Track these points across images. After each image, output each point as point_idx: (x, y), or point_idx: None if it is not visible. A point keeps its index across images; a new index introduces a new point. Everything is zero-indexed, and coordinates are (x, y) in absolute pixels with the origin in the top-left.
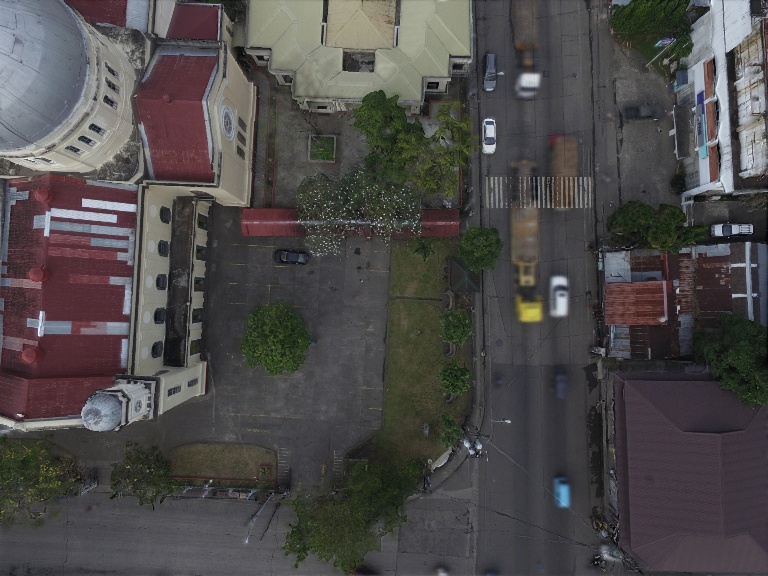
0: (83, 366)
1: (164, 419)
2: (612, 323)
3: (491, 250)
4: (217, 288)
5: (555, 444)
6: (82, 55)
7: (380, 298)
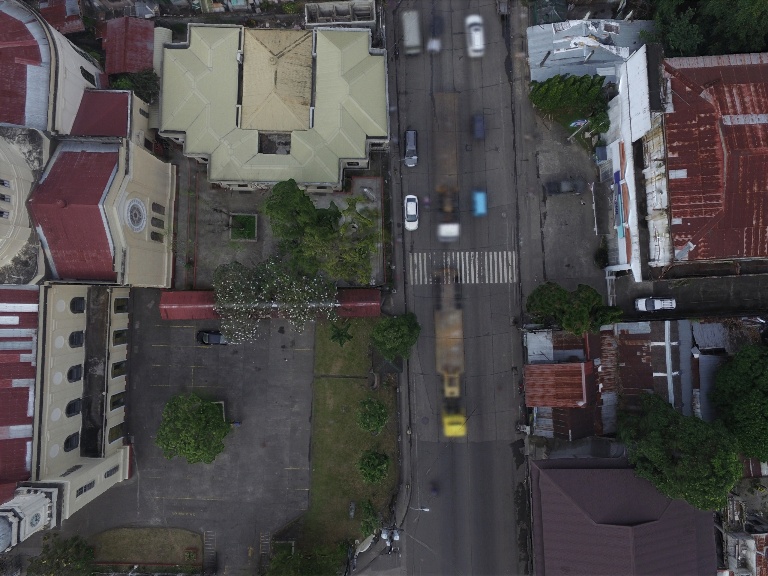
0: None
1: (88, 504)
2: (533, 405)
3: (403, 341)
4: (139, 370)
5: (483, 522)
6: None
7: (305, 377)
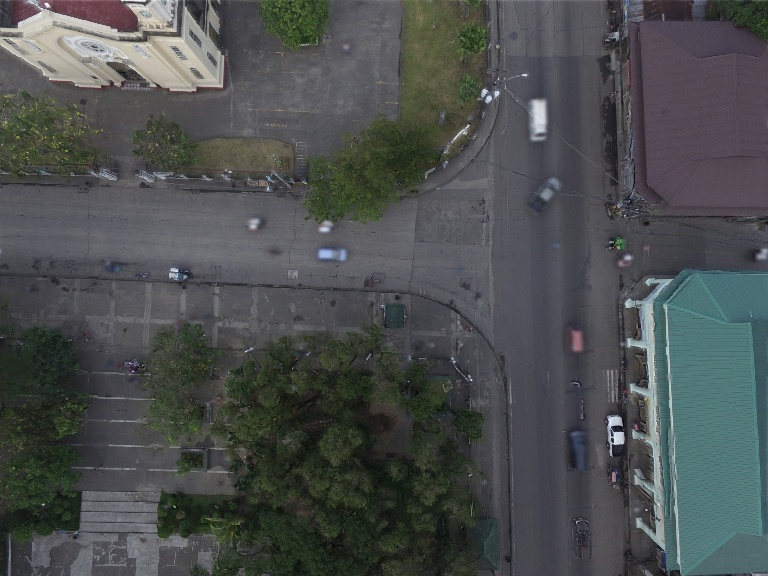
0: None
1: (183, 115)
2: None
3: None
4: None
5: (569, 133)
6: None
7: None
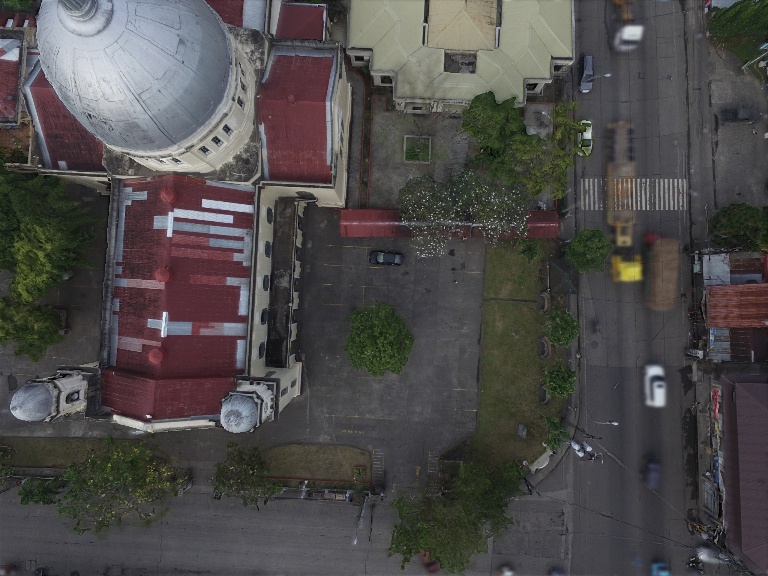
0: (202, 367)
1: None
2: (715, 326)
3: (603, 252)
4: (311, 289)
5: (650, 446)
6: (227, 55)
7: (474, 299)
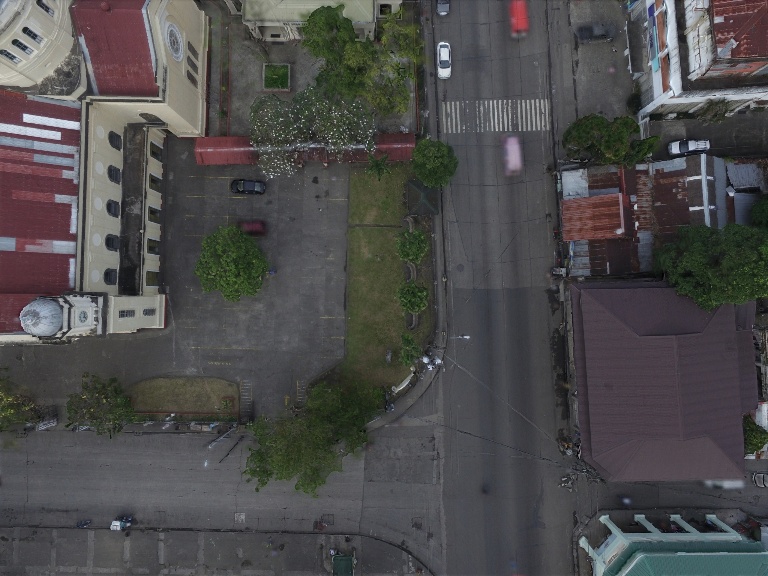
0: (29, 284)
1: (123, 355)
2: (570, 239)
3: (443, 162)
4: (174, 221)
5: (519, 367)
6: None
7: (339, 226)
